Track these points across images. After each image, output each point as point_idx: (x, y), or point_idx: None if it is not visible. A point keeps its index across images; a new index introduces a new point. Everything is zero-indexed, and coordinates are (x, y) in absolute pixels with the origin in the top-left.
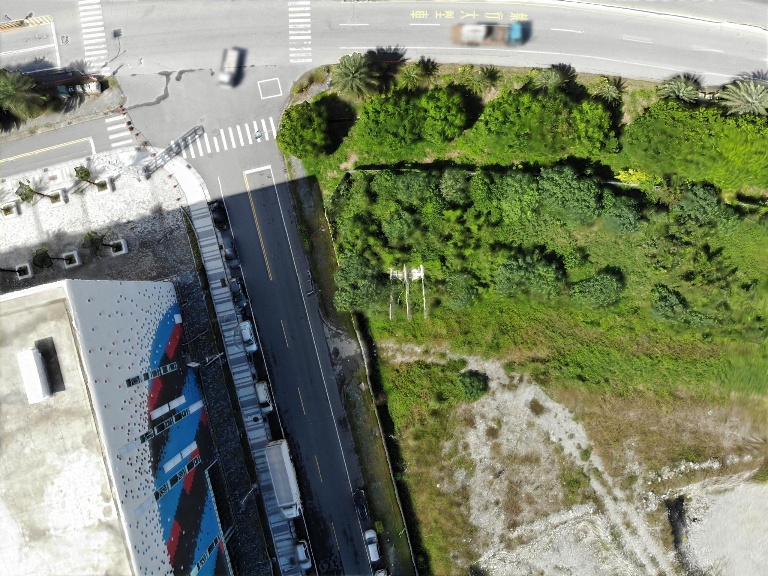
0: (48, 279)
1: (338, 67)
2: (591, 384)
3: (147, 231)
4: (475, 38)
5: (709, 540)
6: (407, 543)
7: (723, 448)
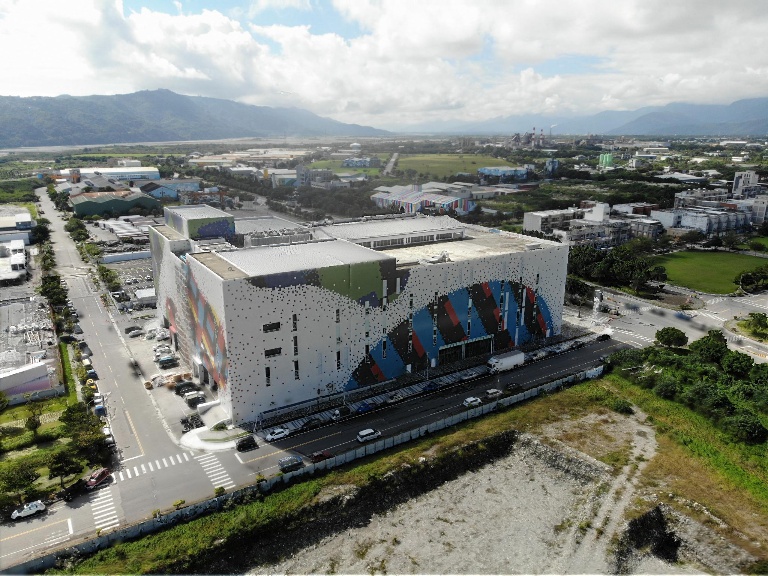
0: None
1: None
2: (688, 447)
3: (574, 327)
4: None
5: (659, 575)
6: None
7: (741, 528)
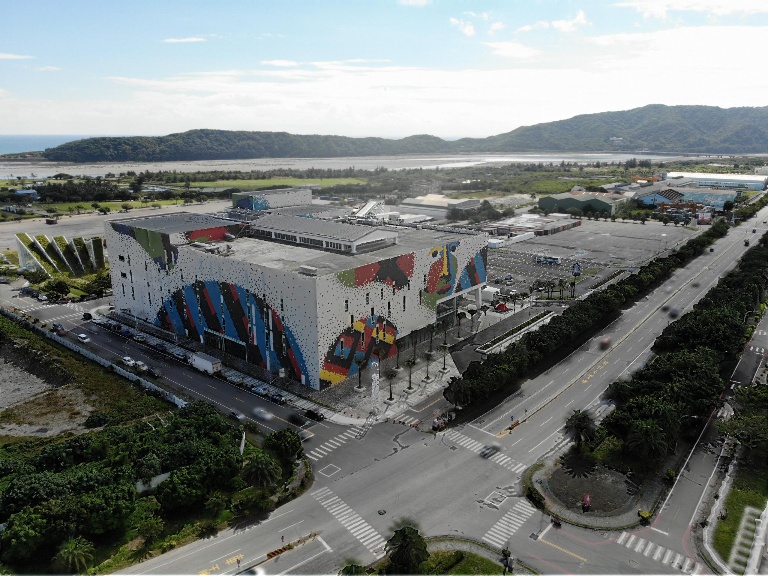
0: None
1: (278, 469)
2: None
3: None
4: (169, 570)
5: None
6: None
7: None
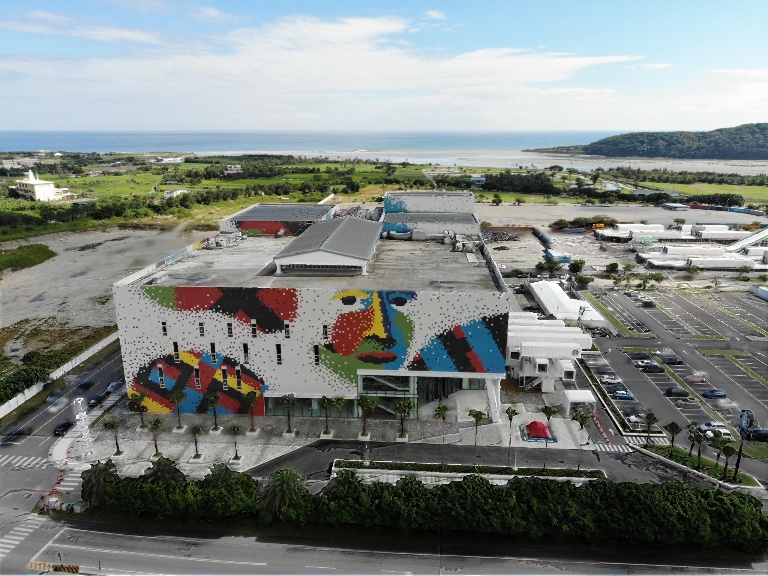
0: (206, 426)
1: None
2: None
3: None
4: None
5: None
6: None
7: None
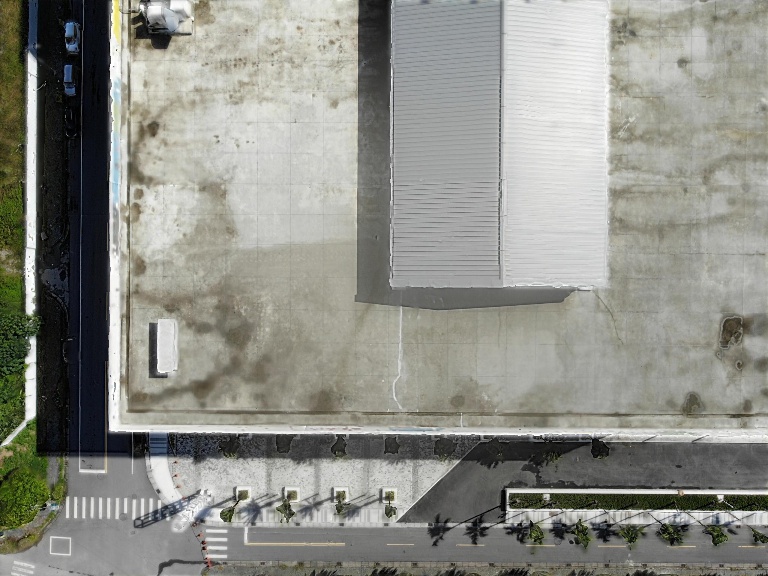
0: None
1: None
2: None
3: (214, 440)
4: None
5: None
6: (41, 74)
7: None
